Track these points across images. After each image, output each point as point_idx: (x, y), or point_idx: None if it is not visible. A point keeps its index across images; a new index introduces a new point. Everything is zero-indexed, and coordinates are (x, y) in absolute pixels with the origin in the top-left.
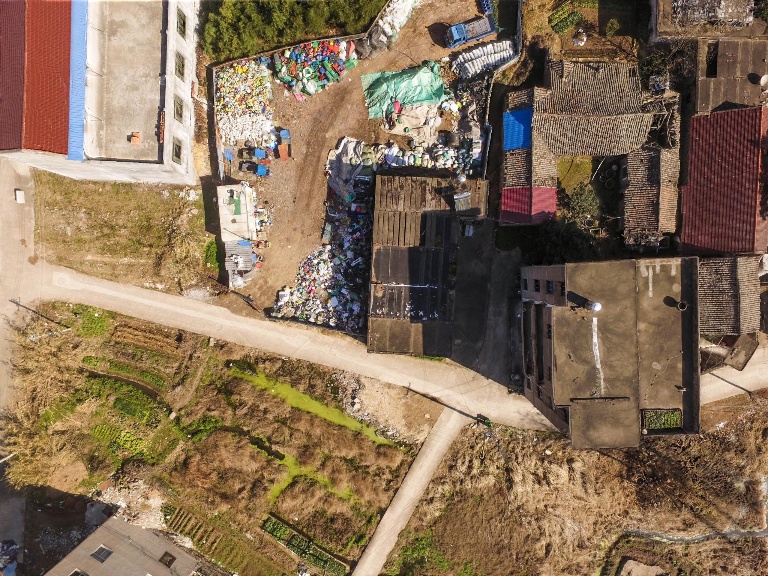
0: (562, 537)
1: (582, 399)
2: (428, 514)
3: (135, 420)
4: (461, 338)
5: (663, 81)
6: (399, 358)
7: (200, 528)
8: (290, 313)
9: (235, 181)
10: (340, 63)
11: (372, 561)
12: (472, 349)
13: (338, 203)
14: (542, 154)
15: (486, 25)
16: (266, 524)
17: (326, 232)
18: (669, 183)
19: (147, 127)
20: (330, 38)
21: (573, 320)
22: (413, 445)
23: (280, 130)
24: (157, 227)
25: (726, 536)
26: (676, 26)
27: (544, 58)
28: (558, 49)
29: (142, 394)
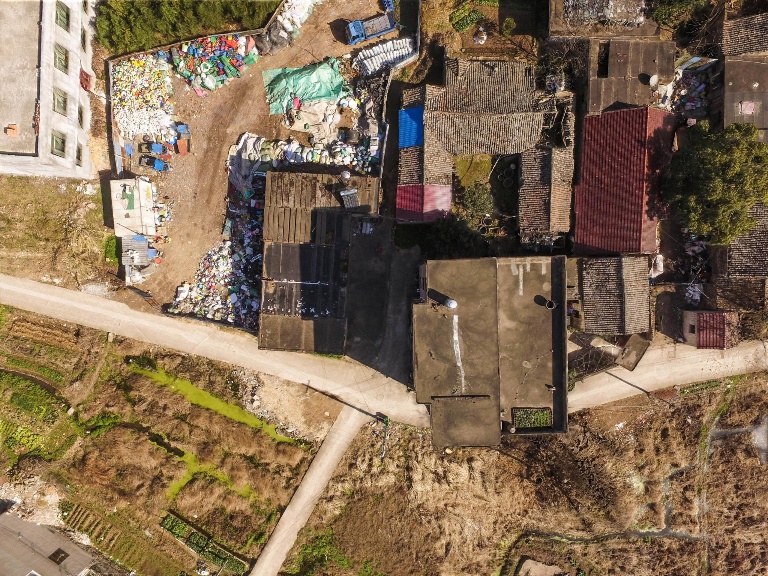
0: (462, 536)
1: (443, 397)
2: (328, 512)
3: (32, 415)
4: (360, 336)
5: (558, 80)
6: (298, 355)
7: (98, 525)
8: (188, 309)
9: (135, 176)
10: (239, 58)
11: (271, 559)
12: (371, 347)
13: (239, 199)
14: (436, 152)
15: (386, 22)
16: (165, 521)
17: (226, 228)
18: (562, 183)
19: (24, 119)
20: (227, 33)
21: (434, 318)
22: (313, 443)
23: None
24: (54, 221)
25: (625, 536)
26: (568, 26)
27: (443, 56)
28: (458, 47)
29: (40, 389)
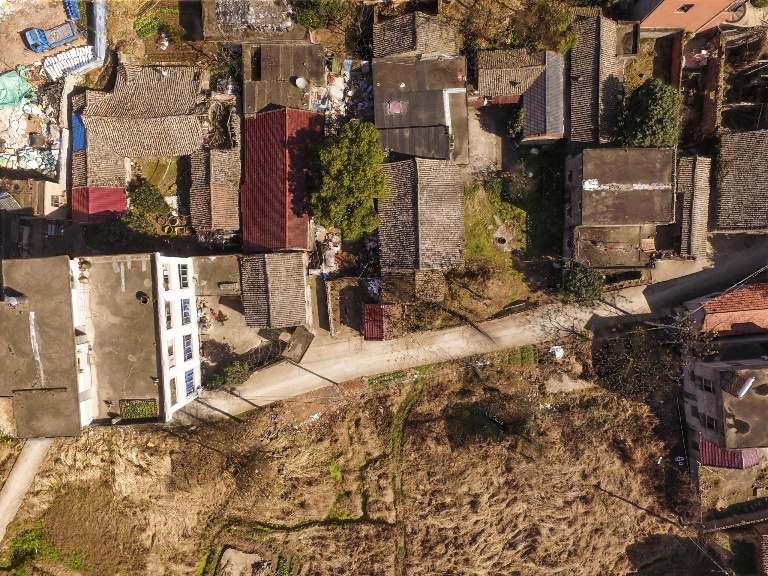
0: (166, 527)
1: (22, 390)
2: (36, 506)
3: None
4: None
5: (225, 84)
6: None
7: None
8: None
9: None
10: None
11: None
12: None
13: None
14: (104, 155)
15: (68, 30)
16: None
17: None
18: (228, 182)
19: None
20: None
21: (12, 314)
22: (20, 439)
23: None
24: None
25: (325, 524)
26: (221, 31)
27: None
28: (142, 53)
29: None
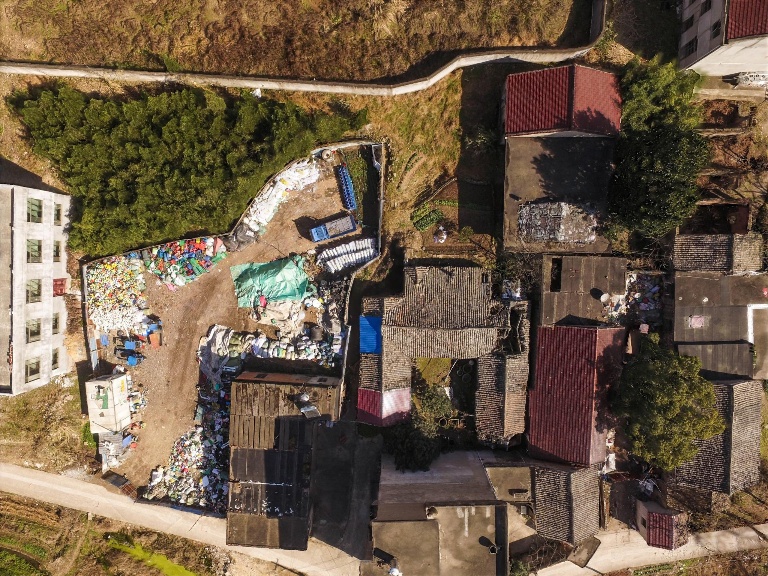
0: None
1: None
2: None
3: None
4: (326, 518)
5: (514, 287)
6: None
7: None
8: (162, 494)
9: (110, 365)
10: (207, 259)
11: None
12: (336, 529)
13: (210, 387)
14: (394, 358)
15: (348, 223)
16: None
17: (198, 415)
18: (517, 387)
19: None
20: (195, 237)
21: (380, 574)
22: None
23: (153, 317)
24: (34, 411)
25: None
26: (522, 242)
27: (403, 257)
28: (419, 245)
29: (25, 563)
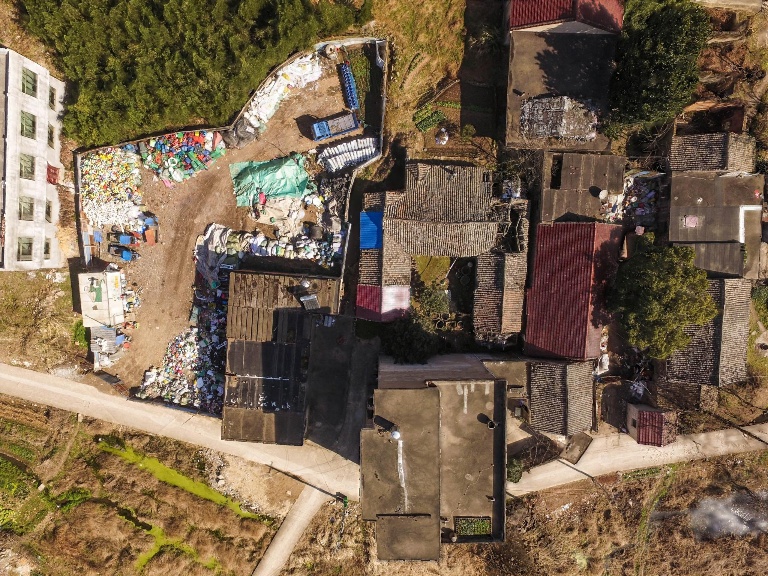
0: None
1: (387, 515)
2: None
3: (3, 491)
4: (322, 421)
5: (514, 186)
6: None
7: None
8: (155, 394)
9: (104, 263)
10: (206, 154)
11: None
12: (332, 431)
13: (206, 287)
14: (395, 254)
15: (350, 121)
16: None
17: (193, 315)
18: (515, 286)
19: None
20: (195, 130)
21: (380, 442)
22: (276, 519)
23: (149, 214)
24: (24, 307)
25: None
26: (523, 138)
27: (405, 157)
28: (421, 147)
29: (11, 466)
